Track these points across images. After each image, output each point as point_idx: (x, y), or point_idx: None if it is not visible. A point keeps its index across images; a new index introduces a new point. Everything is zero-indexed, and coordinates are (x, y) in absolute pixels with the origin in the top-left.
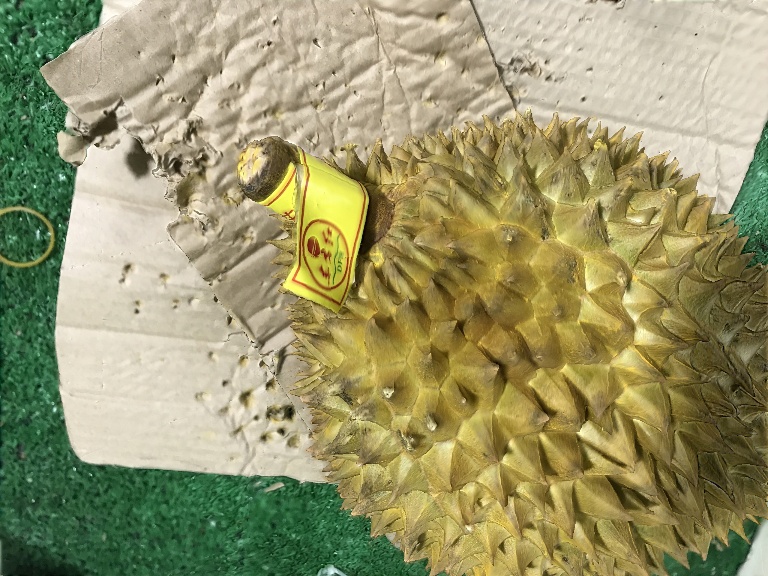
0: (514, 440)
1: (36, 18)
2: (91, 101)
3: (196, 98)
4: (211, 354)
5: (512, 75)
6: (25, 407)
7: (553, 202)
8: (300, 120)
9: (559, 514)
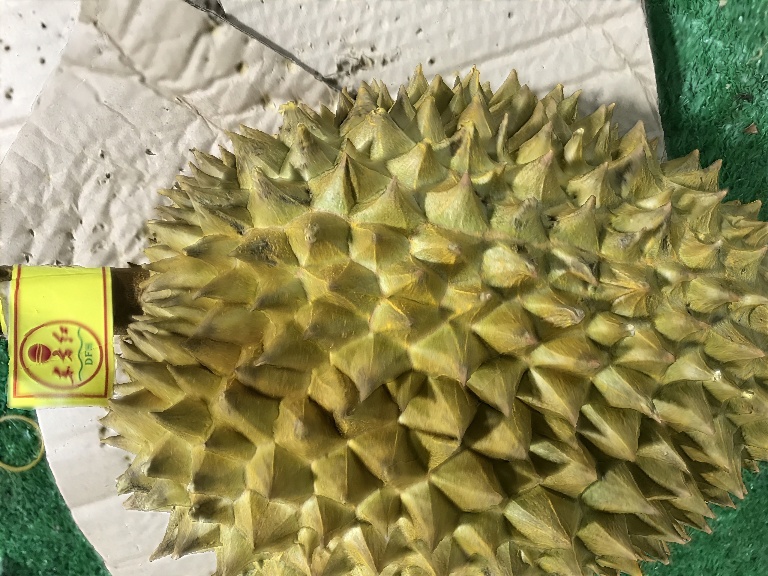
0: (316, 463)
1: None
2: None
3: (70, 256)
4: None
5: (348, 80)
6: None
7: (246, 191)
8: None
9: (417, 527)
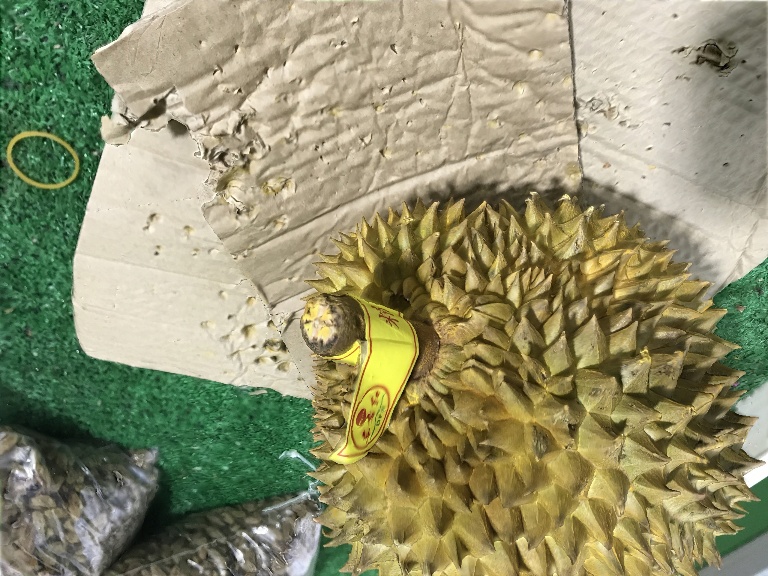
0: None
1: None
2: (142, 90)
3: (253, 88)
4: (221, 292)
5: (587, 112)
6: (36, 300)
7: (585, 412)
8: (357, 120)
9: None
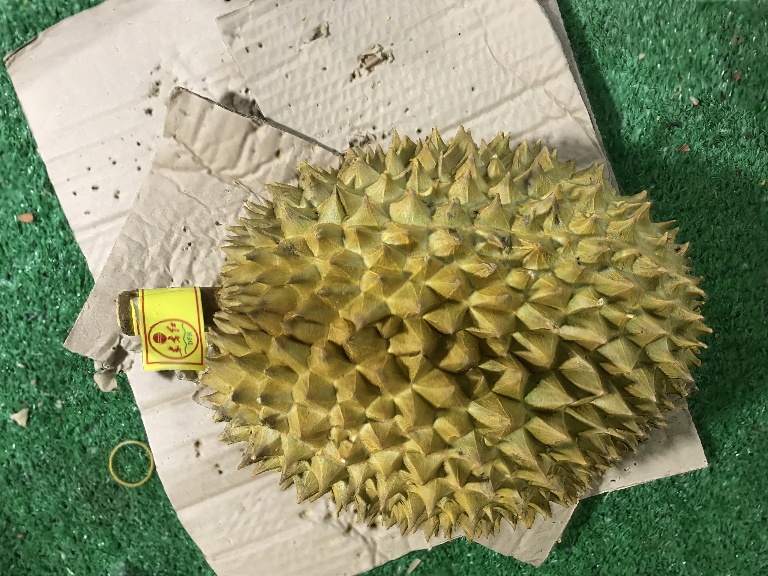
0: (337, 382)
1: (71, 321)
2: (102, 347)
3: None
4: None
5: None
6: None
7: (280, 219)
8: None
9: (405, 416)
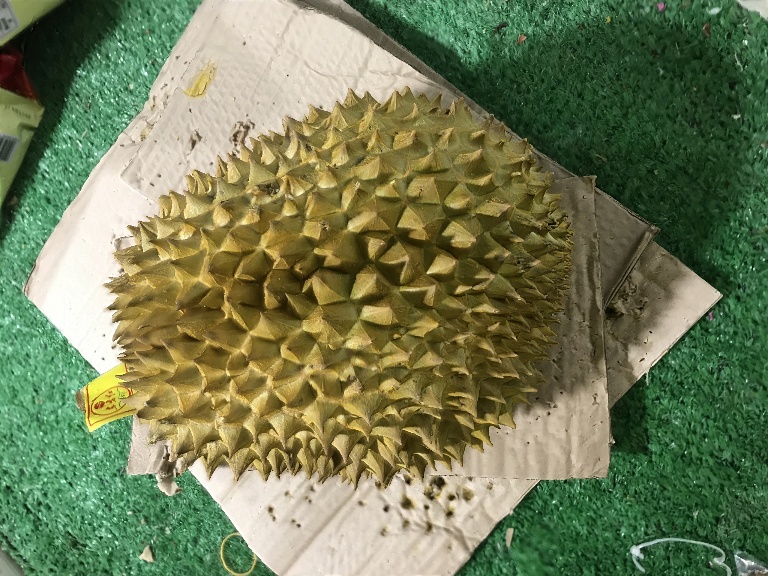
0: None
1: None
2: (155, 461)
3: None
4: (361, 503)
5: None
6: None
7: None
8: None
9: None
